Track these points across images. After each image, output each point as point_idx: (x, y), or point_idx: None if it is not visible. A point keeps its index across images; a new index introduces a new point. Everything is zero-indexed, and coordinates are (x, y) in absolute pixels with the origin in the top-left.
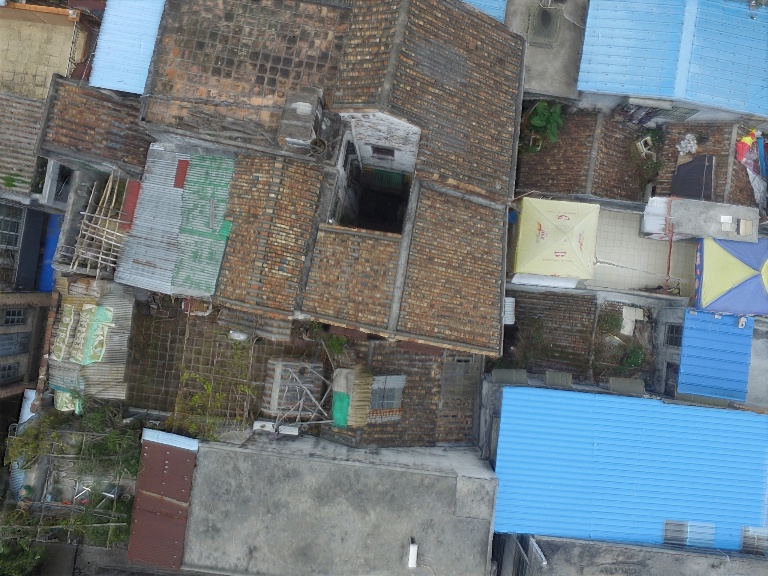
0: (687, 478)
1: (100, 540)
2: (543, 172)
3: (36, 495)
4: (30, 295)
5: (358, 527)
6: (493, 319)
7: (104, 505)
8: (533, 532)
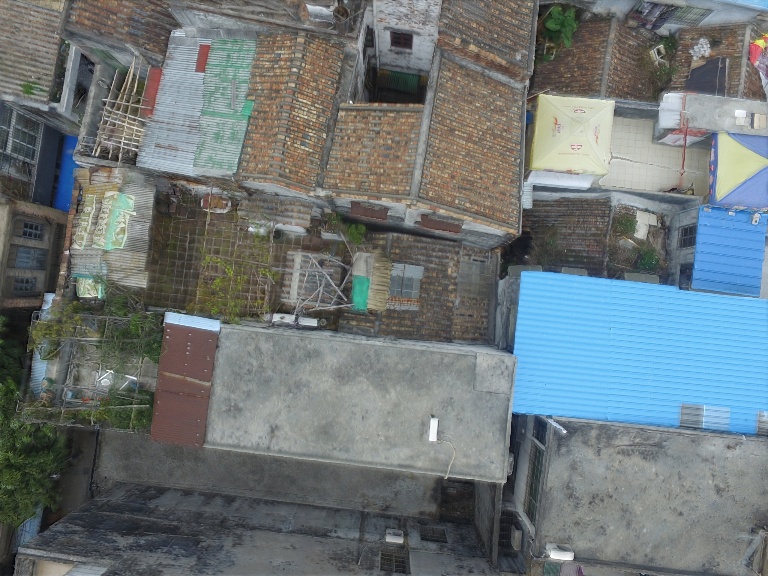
0: (703, 363)
1: (122, 425)
2: (557, 80)
3: (57, 390)
4: (47, 209)
5: (378, 405)
6: (512, 197)
7: (127, 388)
8: (551, 413)
